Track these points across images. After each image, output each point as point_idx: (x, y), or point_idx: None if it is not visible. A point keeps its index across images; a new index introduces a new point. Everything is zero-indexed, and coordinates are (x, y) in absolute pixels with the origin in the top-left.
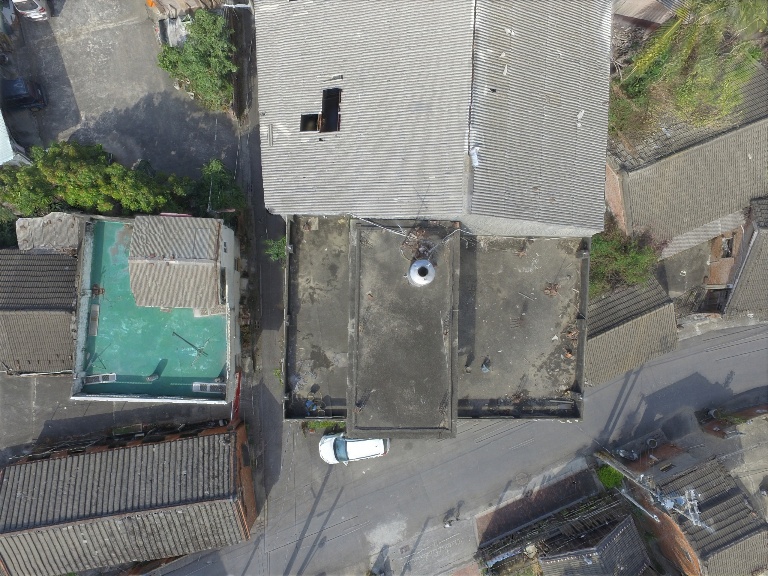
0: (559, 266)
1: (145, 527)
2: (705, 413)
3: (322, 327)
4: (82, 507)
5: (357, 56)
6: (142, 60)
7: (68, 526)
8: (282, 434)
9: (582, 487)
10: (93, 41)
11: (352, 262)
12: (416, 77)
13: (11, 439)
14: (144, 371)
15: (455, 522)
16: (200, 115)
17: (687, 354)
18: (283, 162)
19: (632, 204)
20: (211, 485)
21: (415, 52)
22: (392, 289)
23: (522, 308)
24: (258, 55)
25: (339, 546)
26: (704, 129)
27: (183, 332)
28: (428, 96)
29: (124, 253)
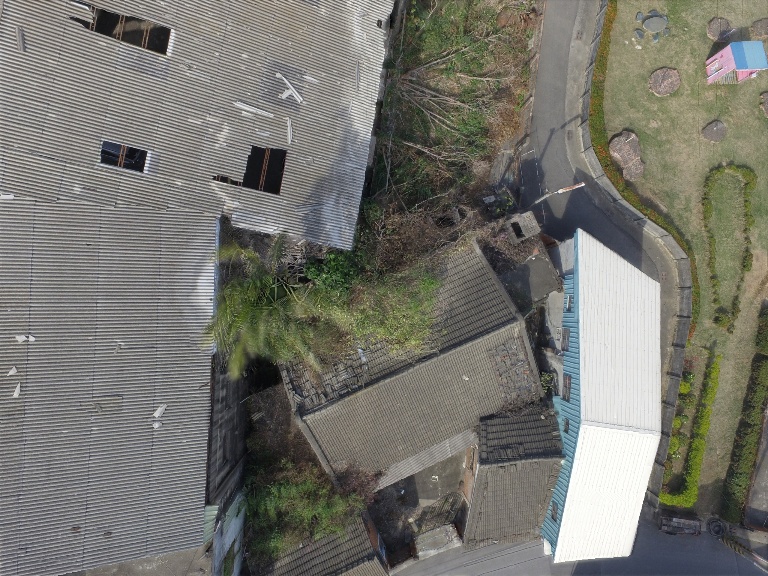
0: (190, 558)
1: None
2: None
3: None
4: None
5: None
6: None
7: None
8: None
9: None
10: None
11: None
12: None
13: None
14: None
15: None
16: None
17: (443, 570)
18: None
19: (322, 443)
20: None
21: None
22: None
23: None
24: None
25: None
26: (405, 352)
27: None
28: None
29: None
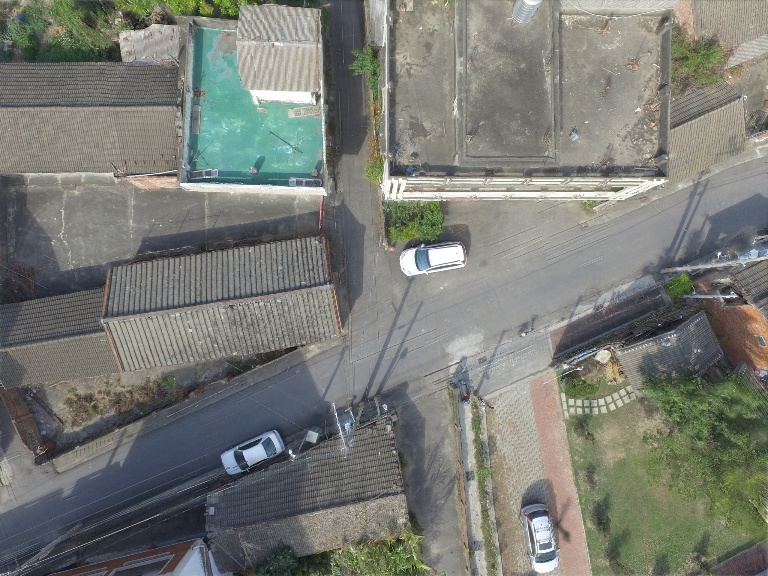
0: (640, 43)
1: (246, 318)
2: (767, 233)
3: (419, 99)
4: (188, 297)
5: None
6: None
7: (176, 313)
8: (363, 252)
9: (650, 302)
10: None
11: (459, 6)
12: None
13: (111, 255)
14: (244, 167)
15: (529, 335)
16: None
17: (749, 176)
18: None
19: (702, 5)
20: (307, 277)
21: None
22: (497, 30)
23: (606, 82)
24: None
25: (420, 357)
26: None
27: (279, 131)
28: None
29: (222, 58)
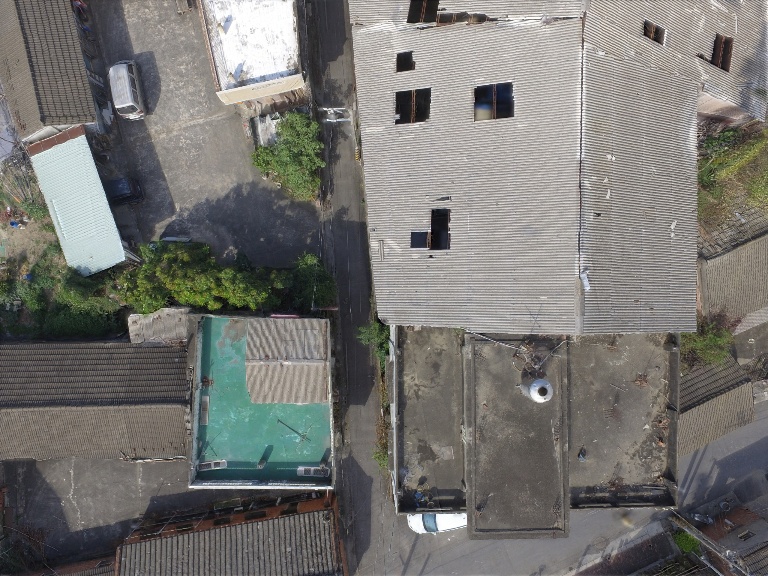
0: (648, 358)
1: None
2: None
3: (427, 422)
4: None
5: (465, 179)
6: (231, 153)
7: None
8: (371, 504)
9: (658, 550)
10: (185, 136)
11: (467, 374)
12: (524, 202)
13: (120, 515)
14: (252, 457)
15: None
16: (286, 203)
17: (757, 419)
18: (395, 276)
19: (709, 287)
20: (315, 562)
21: (522, 178)
22: (505, 399)
23: (614, 399)
24: (366, 174)
25: None
26: None
27: (287, 419)
28: (537, 221)
29: (230, 346)
